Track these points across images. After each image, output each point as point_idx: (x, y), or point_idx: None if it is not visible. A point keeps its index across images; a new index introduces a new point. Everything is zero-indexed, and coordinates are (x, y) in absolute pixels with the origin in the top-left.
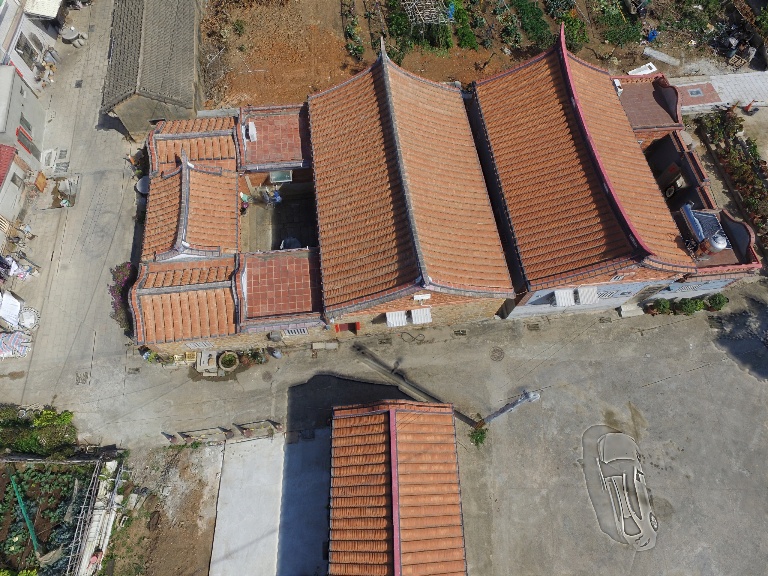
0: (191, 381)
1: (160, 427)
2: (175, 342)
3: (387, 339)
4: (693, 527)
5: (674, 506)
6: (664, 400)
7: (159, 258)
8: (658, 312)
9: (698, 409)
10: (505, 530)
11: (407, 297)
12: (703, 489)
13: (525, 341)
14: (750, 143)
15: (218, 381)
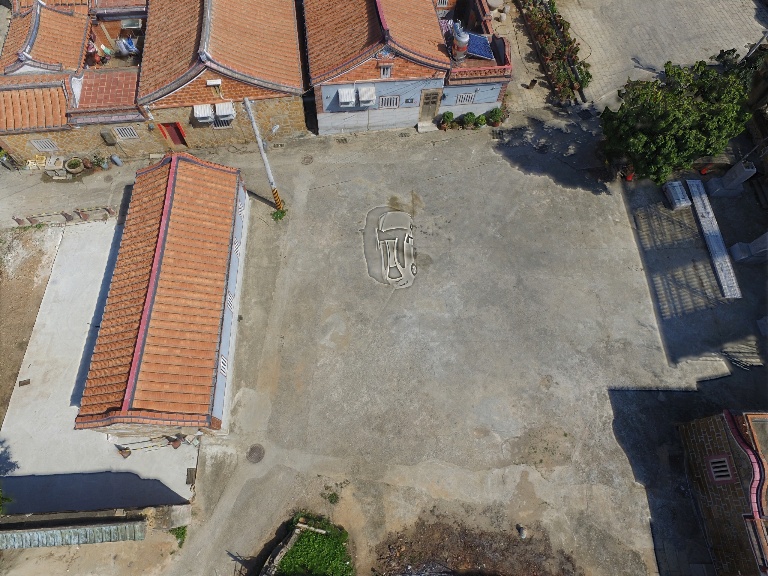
0: (43, 183)
1: (11, 214)
2: (17, 133)
3: (215, 151)
4: (446, 272)
5: (433, 259)
6: (442, 189)
7: (7, 70)
8: (449, 127)
9: (469, 194)
10: (288, 276)
11: (202, 83)
12: (460, 247)
13: (333, 150)
14: (550, 2)
15: (66, 182)
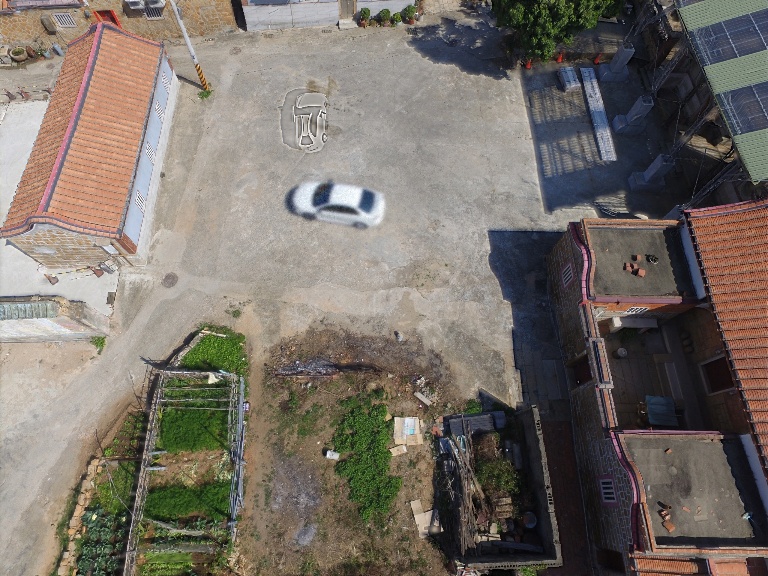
0: None
1: None
2: None
3: None
4: (353, 140)
5: (343, 130)
6: (357, 75)
7: None
8: (368, 24)
9: (381, 79)
10: (210, 143)
11: None
12: (368, 121)
13: (260, 44)
14: None
15: (11, 69)
